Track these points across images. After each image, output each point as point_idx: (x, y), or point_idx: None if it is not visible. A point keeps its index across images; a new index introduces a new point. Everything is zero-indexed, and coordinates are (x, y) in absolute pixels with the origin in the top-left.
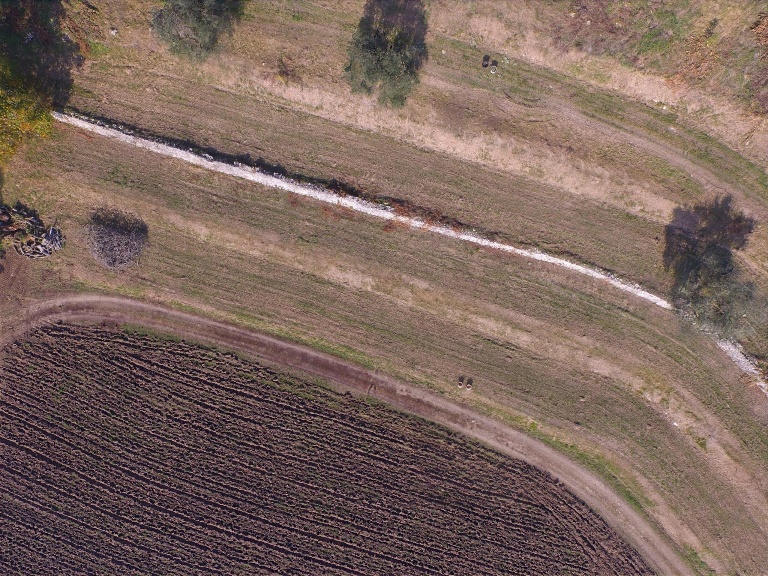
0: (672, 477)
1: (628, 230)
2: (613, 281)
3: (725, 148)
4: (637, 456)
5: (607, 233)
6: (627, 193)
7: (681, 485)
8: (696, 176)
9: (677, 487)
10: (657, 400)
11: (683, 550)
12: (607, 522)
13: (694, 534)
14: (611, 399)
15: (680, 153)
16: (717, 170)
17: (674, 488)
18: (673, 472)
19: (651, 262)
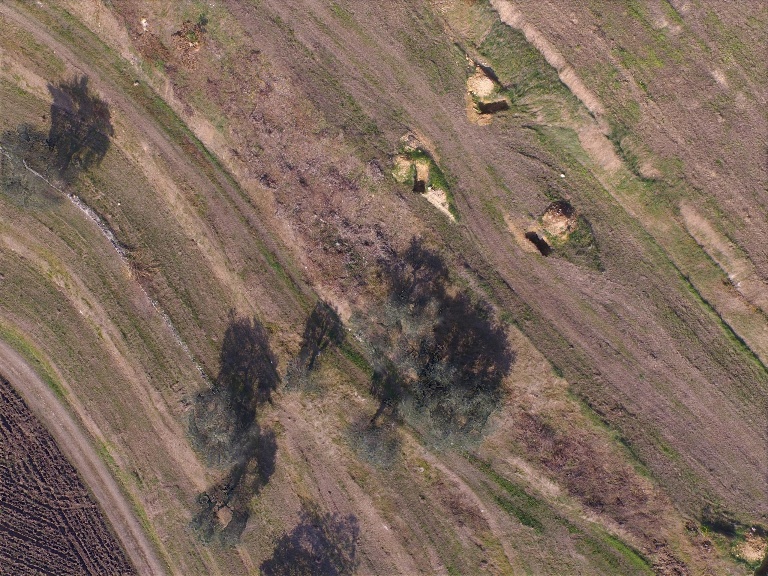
0: (78, 365)
1: (19, 105)
2: (7, 155)
3: (85, 28)
4: (48, 340)
5: (0, 105)
6: (7, 65)
7: (86, 374)
8: (58, 53)
9: (83, 376)
10: (63, 285)
11: (97, 443)
12: (28, 405)
13: (96, 425)
14: (27, 280)
15: (44, 28)
16: (77, 49)
17: (80, 377)
18: (79, 360)
19: (38, 140)
